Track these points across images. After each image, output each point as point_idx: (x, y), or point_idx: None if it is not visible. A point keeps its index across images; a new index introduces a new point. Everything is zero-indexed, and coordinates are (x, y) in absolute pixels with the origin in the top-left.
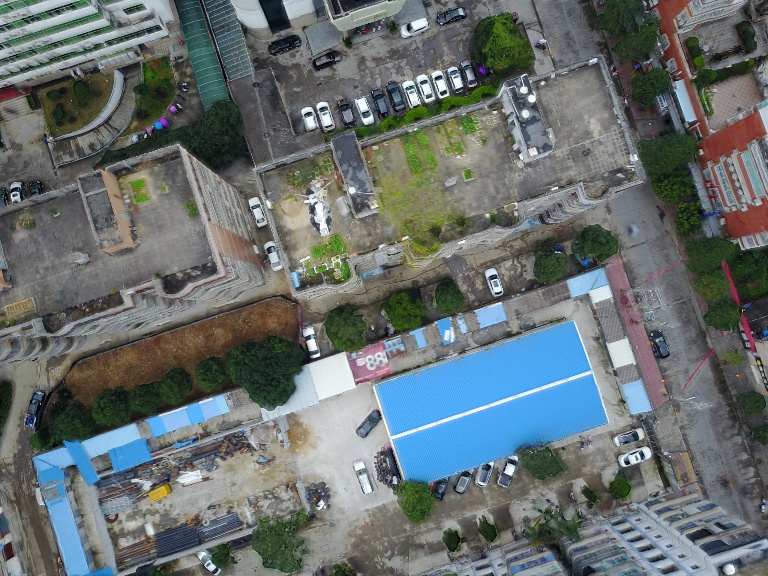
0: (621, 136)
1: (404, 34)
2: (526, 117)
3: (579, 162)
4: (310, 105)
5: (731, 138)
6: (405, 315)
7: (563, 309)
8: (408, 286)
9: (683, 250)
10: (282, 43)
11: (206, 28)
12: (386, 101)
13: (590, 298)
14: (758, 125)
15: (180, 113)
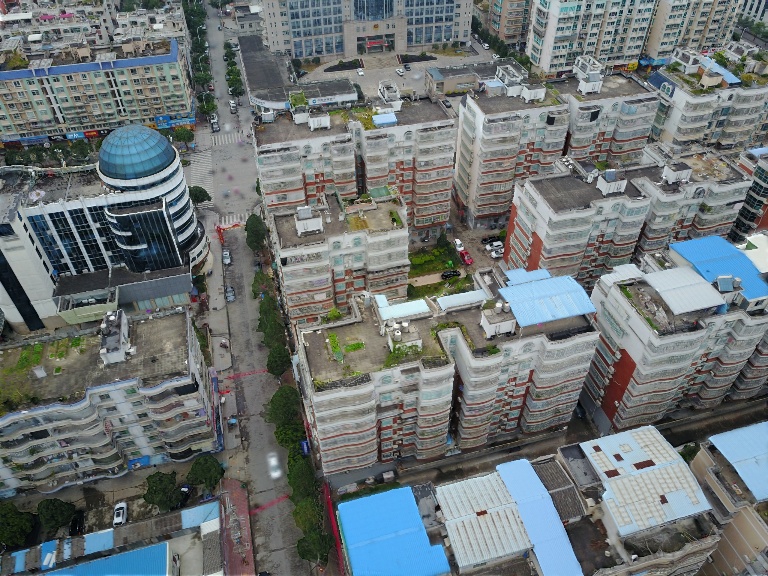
0: (185, 353)
1: None
2: (103, 327)
3: (147, 367)
4: None
5: None
6: (3, 523)
7: (179, 546)
8: None
9: None
10: None
11: None
12: None
13: (200, 530)
14: None
15: None
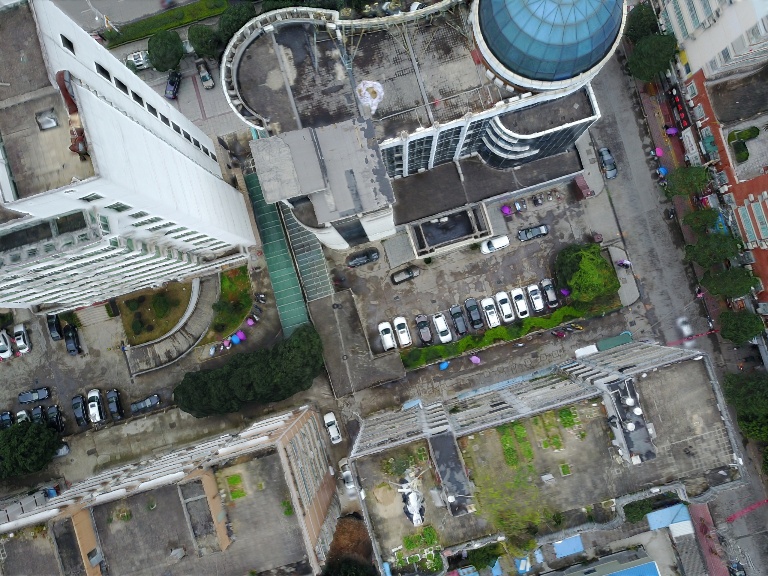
0: (725, 434)
1: (484, 251)
2: (631, 430)
3: (680, 460)
4: (387, 319)
5: None
6: (484, 556)
7: (640, 536)
8: None
9: (766, 479)
10: (360, 255)
11: (286, 248)
12: (464, 319)
13: (670, 532)
14: None
15: (256, 324)
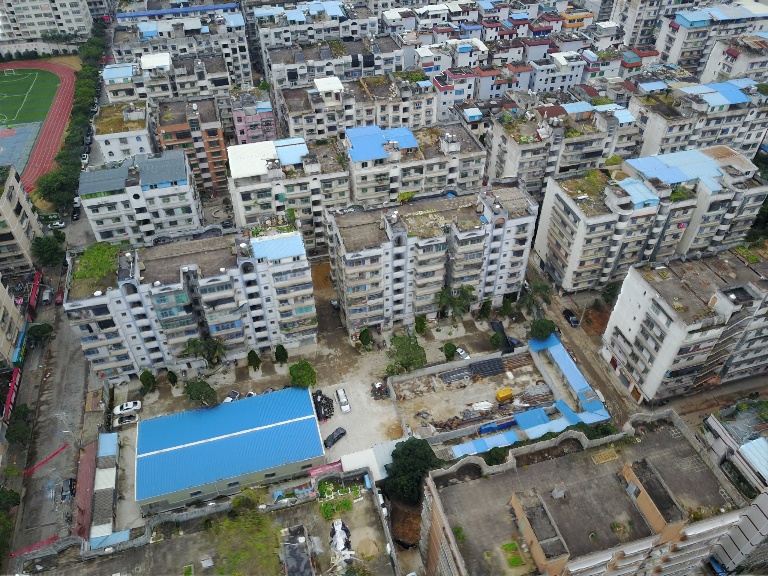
0: None
1: None
2: None
3: None
4: None
5: None
6: None
7: None
8: None
9: None
10: None
11: None
12: None
13: None
14: None
15: None
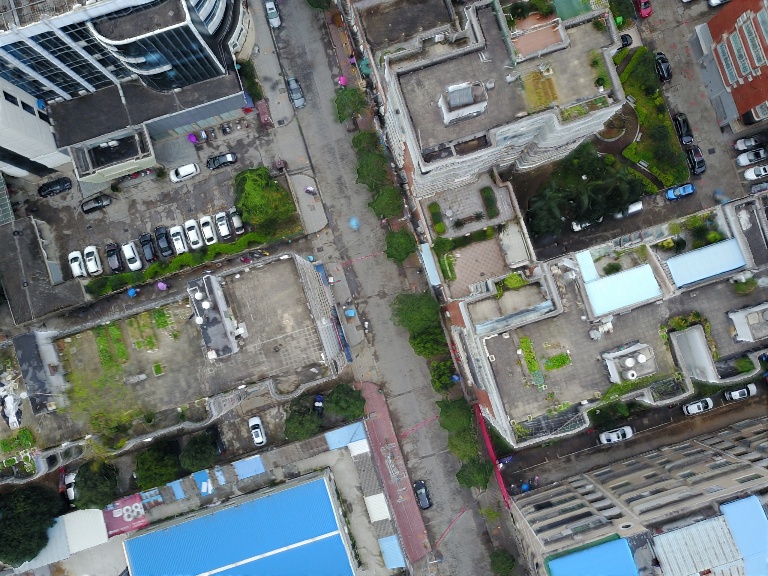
0: (313, 332)
1: (173, 179)
2: None
3: (271, 358)
4: (79, 248)
5: (456, 315)
6: (149, 475)
7: (328, 458)
8: (173, 433)
9: (449, 399)
10: (53, 185)
11: None
12: (153, 247)
13: (349, 451)
14: (461, 316)
15: None
